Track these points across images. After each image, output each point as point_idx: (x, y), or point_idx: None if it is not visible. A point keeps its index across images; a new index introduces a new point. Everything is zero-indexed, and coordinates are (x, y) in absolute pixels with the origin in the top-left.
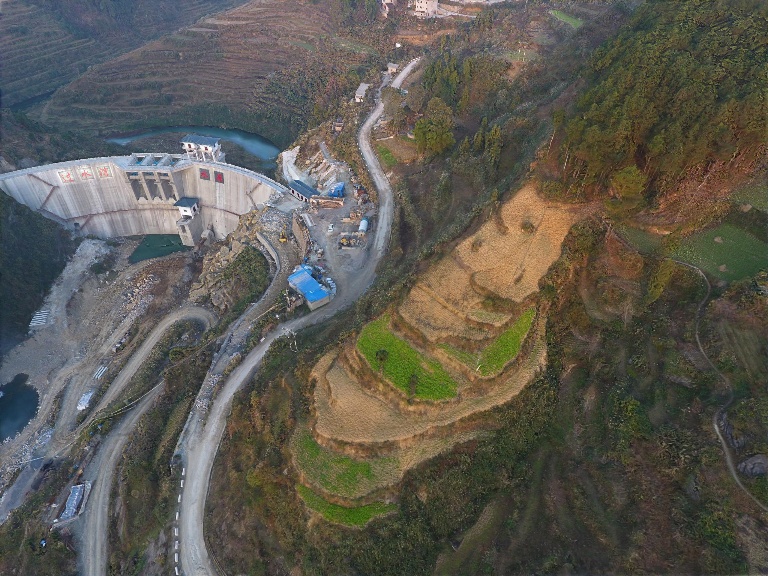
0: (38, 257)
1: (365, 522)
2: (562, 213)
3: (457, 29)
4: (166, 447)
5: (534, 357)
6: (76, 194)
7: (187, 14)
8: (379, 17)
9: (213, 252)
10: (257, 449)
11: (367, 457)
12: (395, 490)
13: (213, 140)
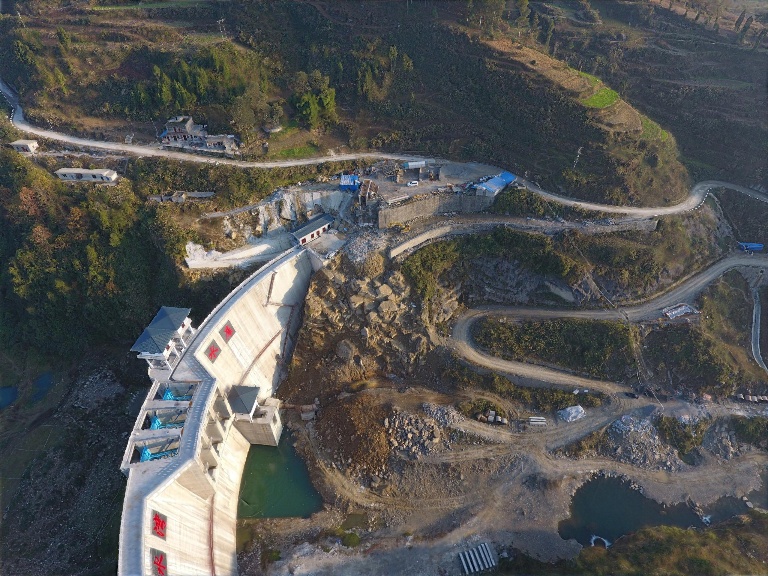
0: None
1: None
2: None
3: None
4: None
5: None
6: None
7: None
8: None
9: (336, 365)
10: (646, 165)
11: None
12: None
13: (171, 310)
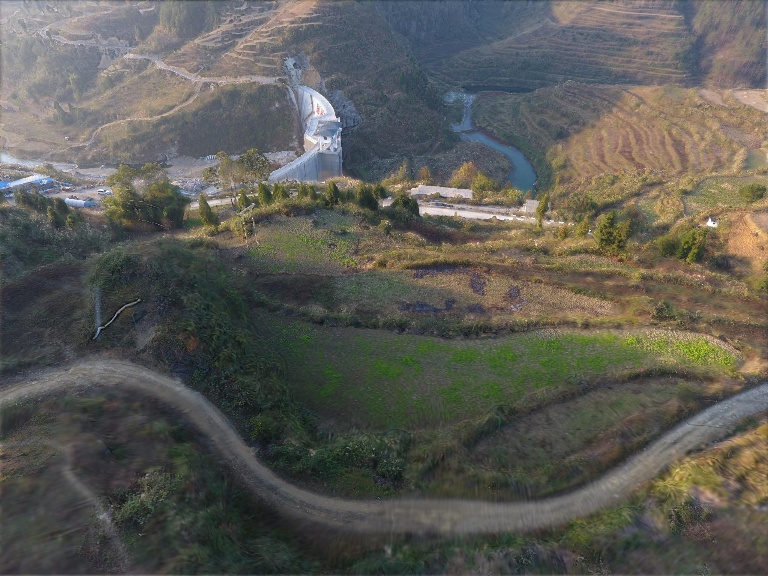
0: None
1: None
2: None
3: None
4: None
5: None
6: None
7: None
8: None
9: None
10: None
11: None
12: None
13: (326, 133)
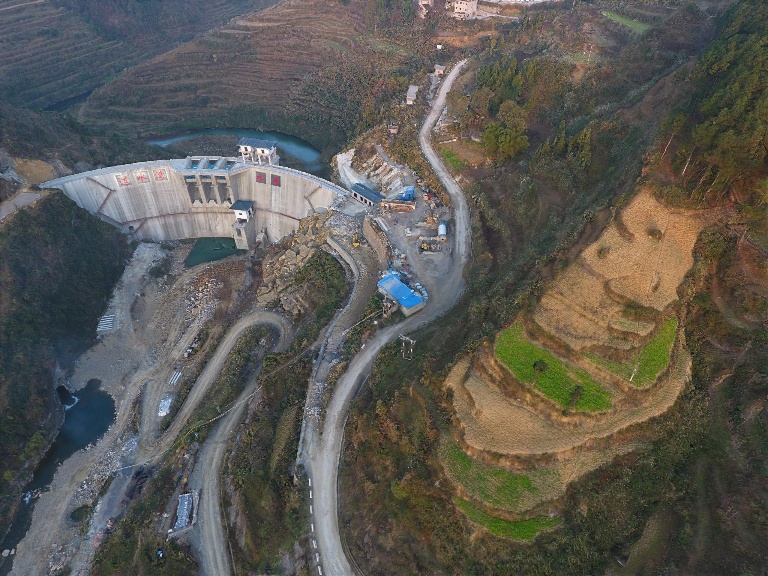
0: (100, 261)
1: (532, 536)
2: (686, 219)
3: (498, 30)
4: (282, 456)
5: (681, 367)
6: (132, 197)
7: (210, 16)
8: (416, 18)
9: (272, 256)
10: (395, 460)
11: (524, 469)
12: (560, 504)
13: (270, 143)
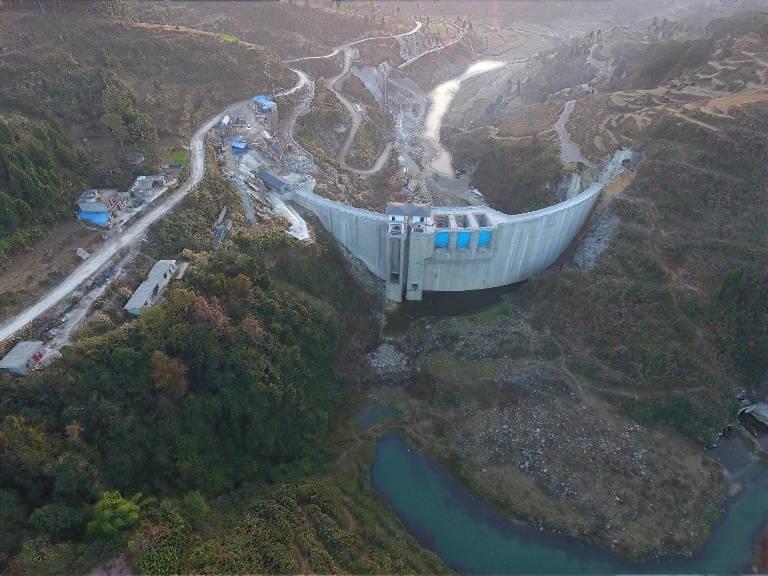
0: None
1: None
2: None
3: None
4: None
5: None
6: None
7: None
8: None
9: None
10: None
11: None
12: None
13: (391, 208)
